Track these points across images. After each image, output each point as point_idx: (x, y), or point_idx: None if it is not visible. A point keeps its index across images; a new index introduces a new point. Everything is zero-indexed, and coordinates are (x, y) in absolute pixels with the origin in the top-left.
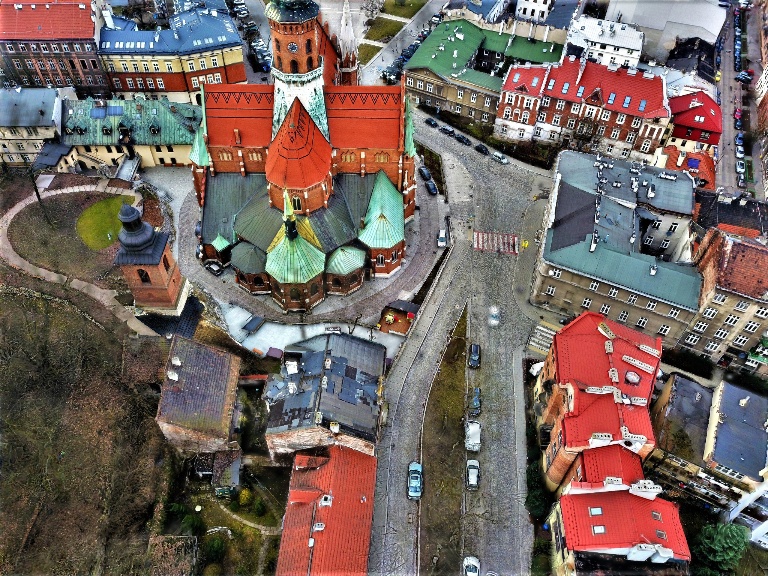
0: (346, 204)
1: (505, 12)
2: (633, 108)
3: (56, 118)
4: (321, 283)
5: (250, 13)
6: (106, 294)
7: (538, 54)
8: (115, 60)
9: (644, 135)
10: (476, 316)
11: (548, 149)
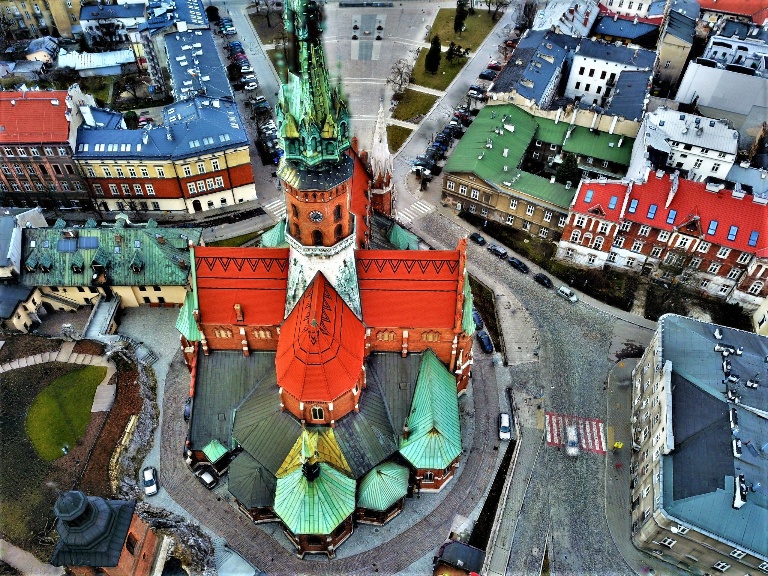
0: (382, 399)
1: (555, 87)
2: (741, 241)
3: (13, 254)
4: (350, 520)
5: (260, 84)
6: (48, 572)
7: (603, 149)
8: (95, 165)
9: (755, 276)
10: (562, 569)
11: (625, 279)
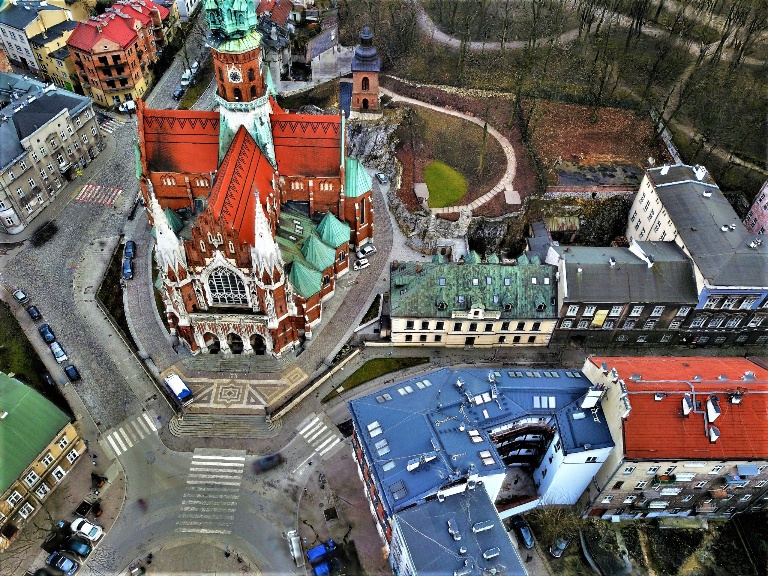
0: None
1: None
2: None
3: None
4: None
5: None
6: (399, 99)
7: None
8: None
9: None
10: None
11: None
